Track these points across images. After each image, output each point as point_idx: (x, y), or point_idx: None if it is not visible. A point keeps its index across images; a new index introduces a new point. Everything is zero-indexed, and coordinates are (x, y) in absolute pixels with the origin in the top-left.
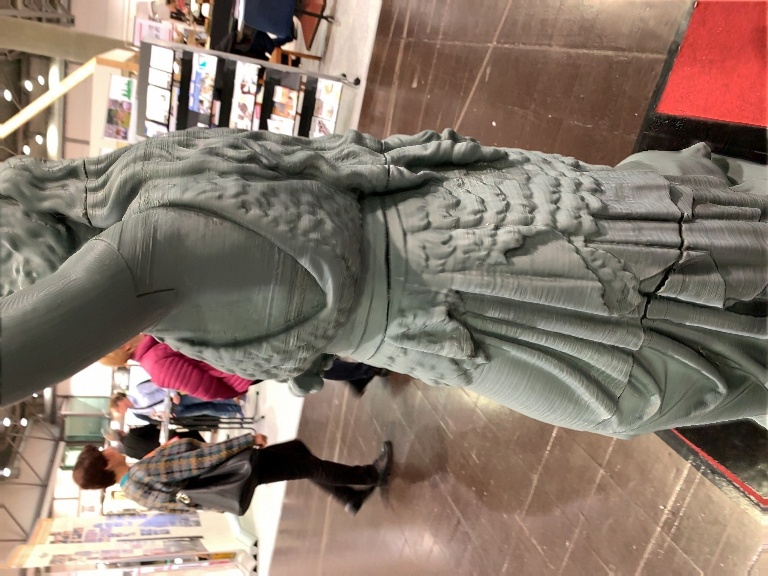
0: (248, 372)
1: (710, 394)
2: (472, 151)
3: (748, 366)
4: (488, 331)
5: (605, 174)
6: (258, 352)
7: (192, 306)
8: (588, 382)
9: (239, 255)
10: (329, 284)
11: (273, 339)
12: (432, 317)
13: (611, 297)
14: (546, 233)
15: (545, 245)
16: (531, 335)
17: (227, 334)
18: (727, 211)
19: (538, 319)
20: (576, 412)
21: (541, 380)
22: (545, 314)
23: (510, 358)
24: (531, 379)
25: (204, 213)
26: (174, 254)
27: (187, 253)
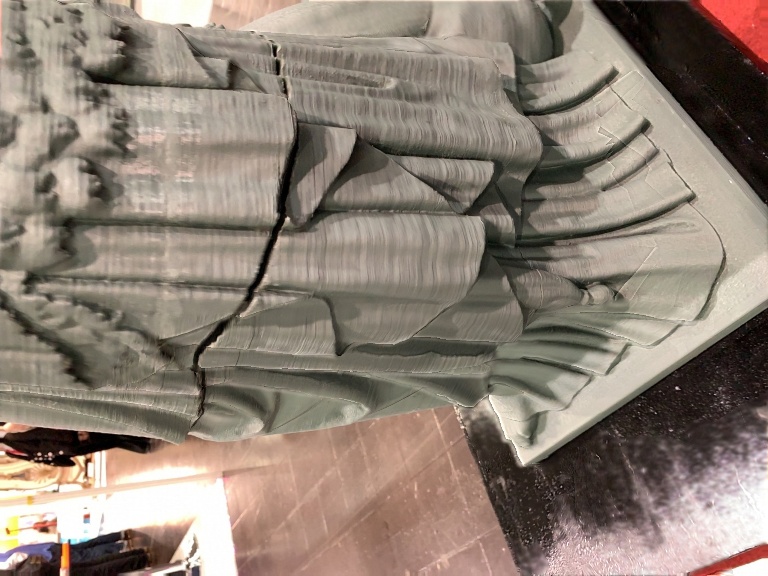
0: None
1: (350, 407)
2: None
3: (408, 384)
4: None
5: (165, 102)
6: None
7: None
8: (128, 417)
9: None
10: None
11: None
12: None
13: (100, 363)
14: None
15: None
16: None
17: None
18: (401, 196)
19: None
20: None
21: (45, 414)
22: None
23: None
24: (25, 414)
25: None
26: None
27: None
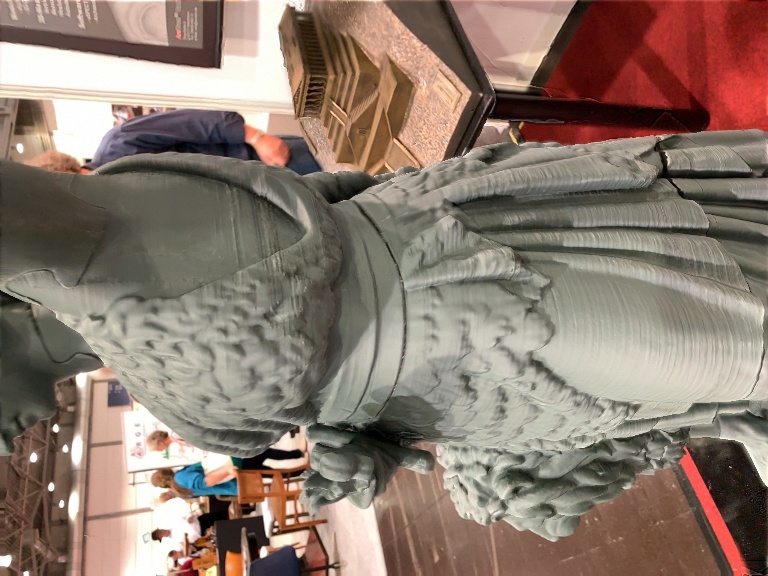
0: (231, 339)
1: None
2: (412, 168)
3: None
4: (522, 246)
5: None
6: (233, 284)
7: (134, 248)
8: (692, 276)
9: (184, 191)
10: (299, 206)
11: (249, 266)
12: (441, 226)
13: None
14: (510, 146)
15: (517, 154)
16: (574, 235)
17: (188, 281)
18: None
19: (566, 212)
20: (719, 326)
21: (634, 291)
22: (569, 207)
23: (574, 274)
24: (621, 292)
25: (138, 171)
26: (104, 185)
27: (120, 187)
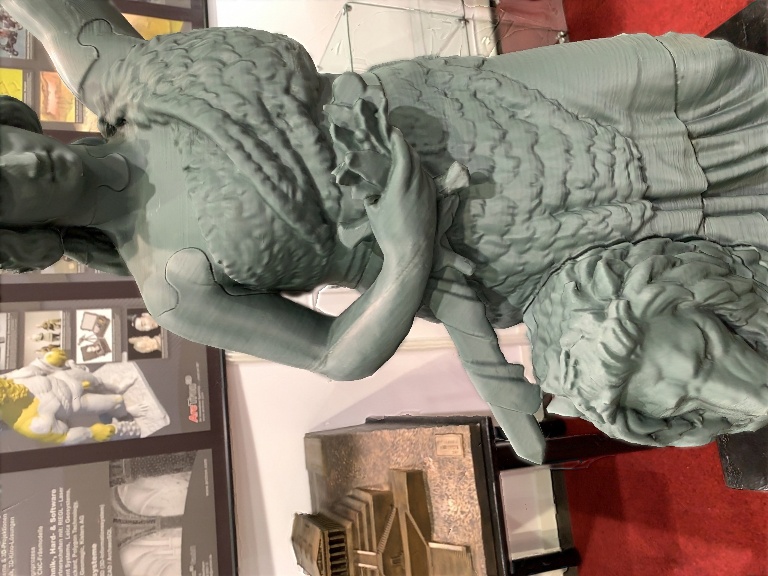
0: None
1: None
2: None
3: None
4: None
5: None
6: None
7: None
8: None
9: None
10: None
11: None
12: None
13: None
14: None
15: None
16: None
17: None
18: None
19: None
20: None
21: None
22: None
23: None
24: None
25: None
26: None
27: None
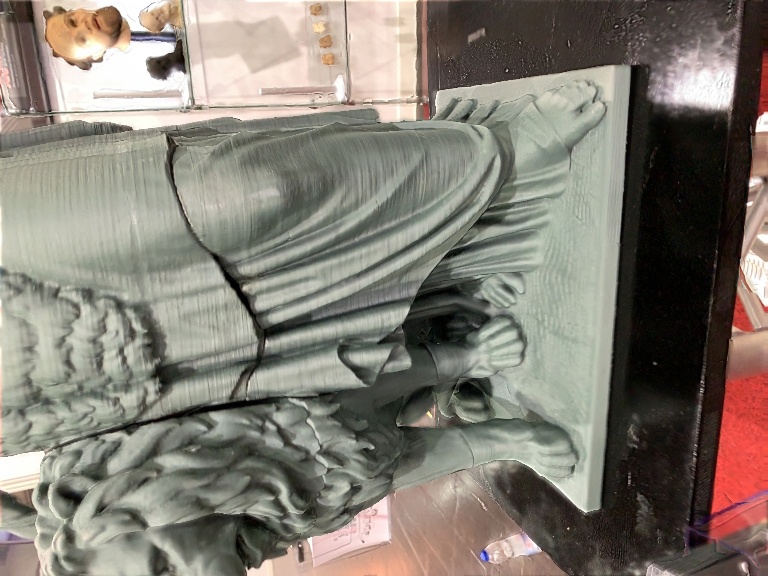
0: None
1: None
2: None
3: None
4: None
5: None
6: None
7: None
8: None
9: None
10: None
11: None
12: None
13: None
14: None
15: None
16: None
17: None
18: None
19: None
20: None
21: None
22: None
23: None
24: None
25: None
26: None
27: None
